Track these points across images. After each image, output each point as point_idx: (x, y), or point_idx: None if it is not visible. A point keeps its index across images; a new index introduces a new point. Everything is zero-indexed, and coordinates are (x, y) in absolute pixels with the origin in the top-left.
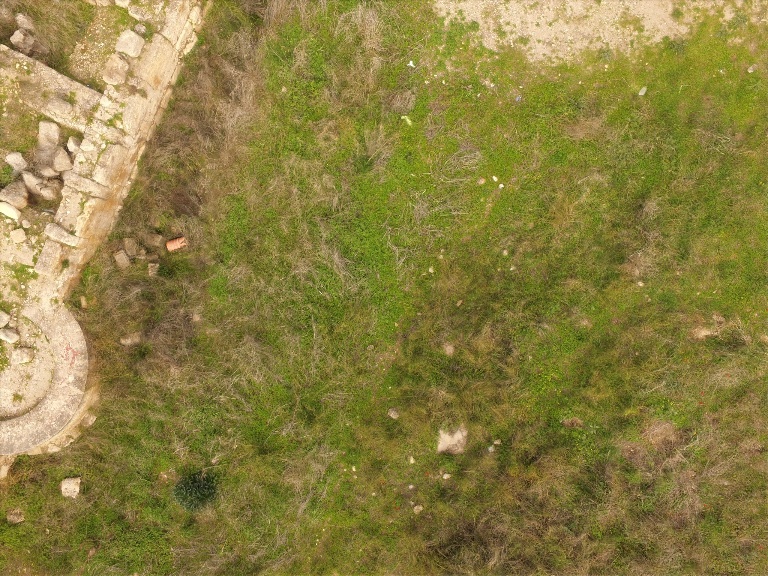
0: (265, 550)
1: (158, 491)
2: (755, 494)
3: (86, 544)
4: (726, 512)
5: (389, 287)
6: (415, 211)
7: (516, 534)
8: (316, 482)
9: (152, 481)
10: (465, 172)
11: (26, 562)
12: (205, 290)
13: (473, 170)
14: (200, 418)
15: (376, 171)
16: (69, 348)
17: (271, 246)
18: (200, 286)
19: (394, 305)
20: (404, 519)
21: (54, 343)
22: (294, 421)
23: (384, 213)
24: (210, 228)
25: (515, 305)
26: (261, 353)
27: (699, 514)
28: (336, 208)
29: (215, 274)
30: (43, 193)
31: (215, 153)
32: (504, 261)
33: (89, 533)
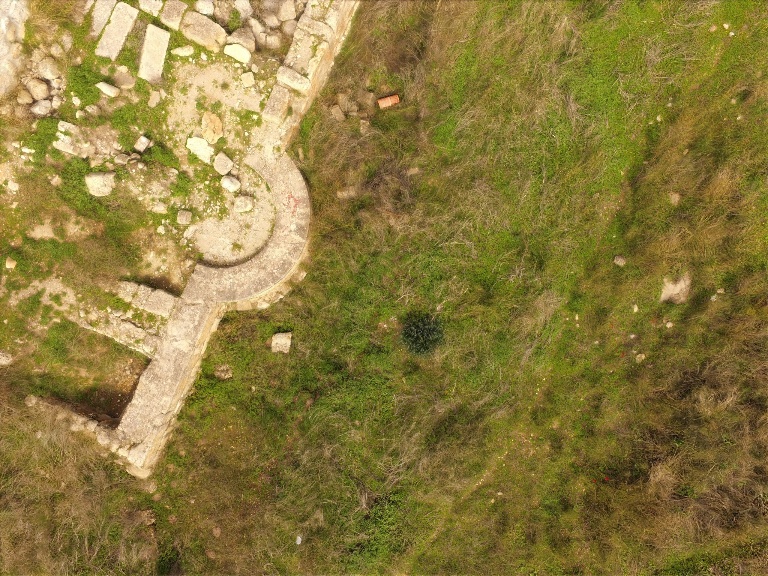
0: None
1: (379, 340)
2: None
3: (302, 395)
4: None
5: (616, 135)
6: (646, 58)
7: (746, 377)
8: (542, 328)
9: (371, 331)
10: (698, 18)
11: (232, 419)
12: (429, 139)
13: (707, 16)
14: (427, 264)
15: (608, 18)
16: (291, 196)
17: (499, 93)
18: (427, 133)
19: (621, 153)
20: (626, 368)
21: (276, 191)
22: (522, 267)
23: (613, 61)
24: (432, 79)
25: (742, 154)
26: (492, 197)
27: None
28: (571, 52)
29: (443, 121)
30: (269, 40)
31: (426, 12)
32: (732, 110)
33: (303, 386)
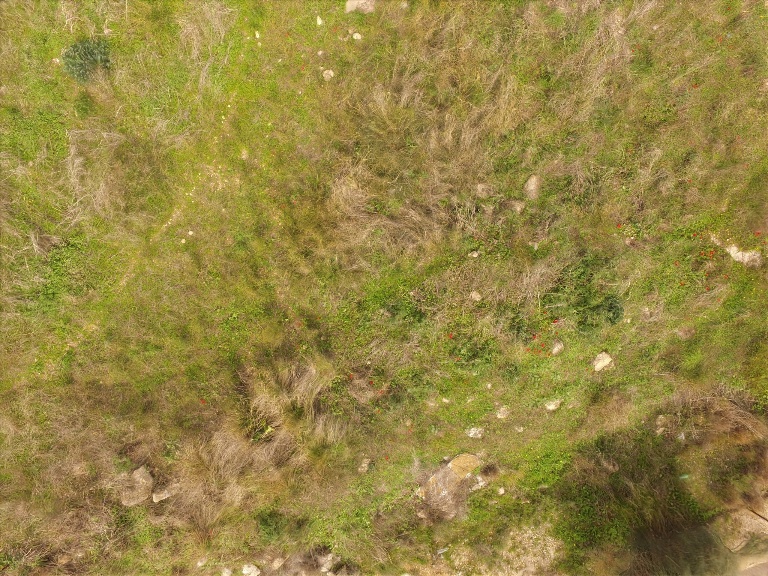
0: (166, 126)
1: (50, 74)
2: (685, 29)
3: None
4: (655, 52)
5: None
6: None
7: (430, 77)
8: (216, 46)
9: (44, 69)
10: None
11: None
12: None
13: None
14: None
15: None
16: None
17: None
18: None
19: None
20: (314, 87)
21: None
22: None
23: None
24: None
25: None
26: None
27: (627, 58)
28: None
29: None
30: None
31: None
32: None
33: None
